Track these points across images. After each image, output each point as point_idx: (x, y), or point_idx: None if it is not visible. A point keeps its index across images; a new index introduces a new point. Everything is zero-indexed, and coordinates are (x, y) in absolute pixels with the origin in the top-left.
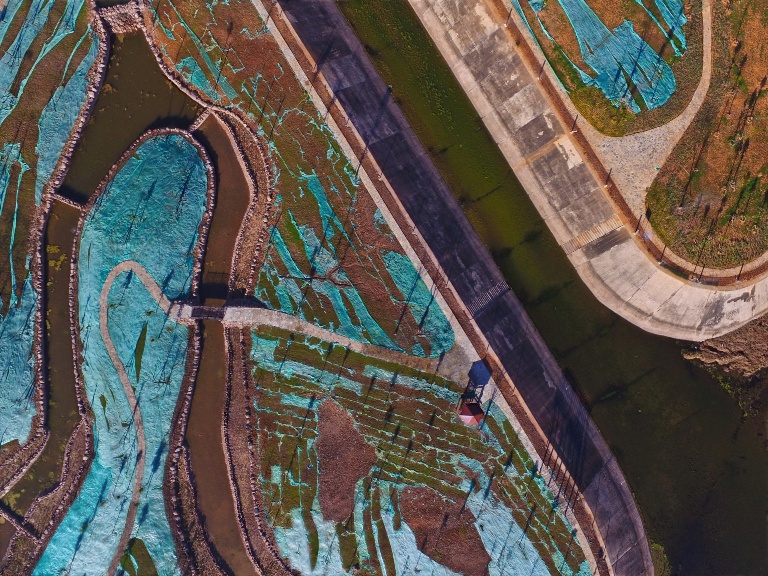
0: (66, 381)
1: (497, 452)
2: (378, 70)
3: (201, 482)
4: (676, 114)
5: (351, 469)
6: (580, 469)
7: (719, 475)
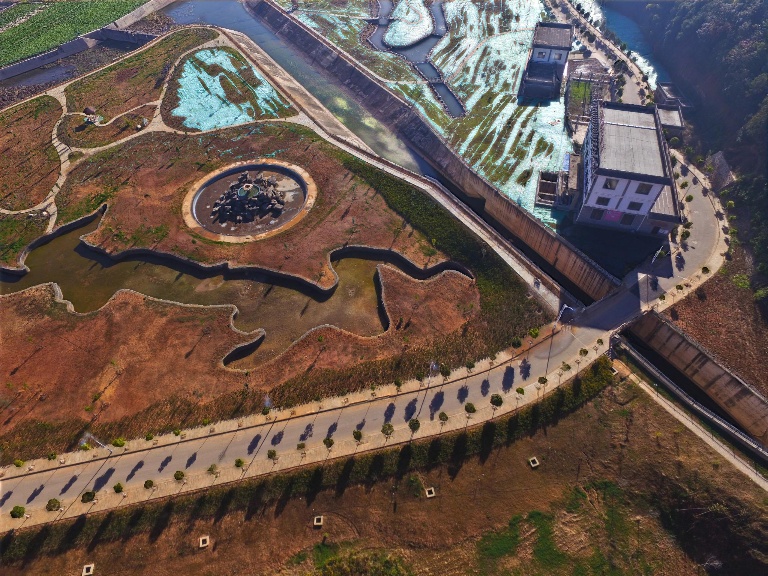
0: (436, 12)
1: (288, 3)
2: (315, 69)
3: (388, 1)
4: (199, 49)
5: (337, 1)
6: (261, 4)
7: (213, 11)
